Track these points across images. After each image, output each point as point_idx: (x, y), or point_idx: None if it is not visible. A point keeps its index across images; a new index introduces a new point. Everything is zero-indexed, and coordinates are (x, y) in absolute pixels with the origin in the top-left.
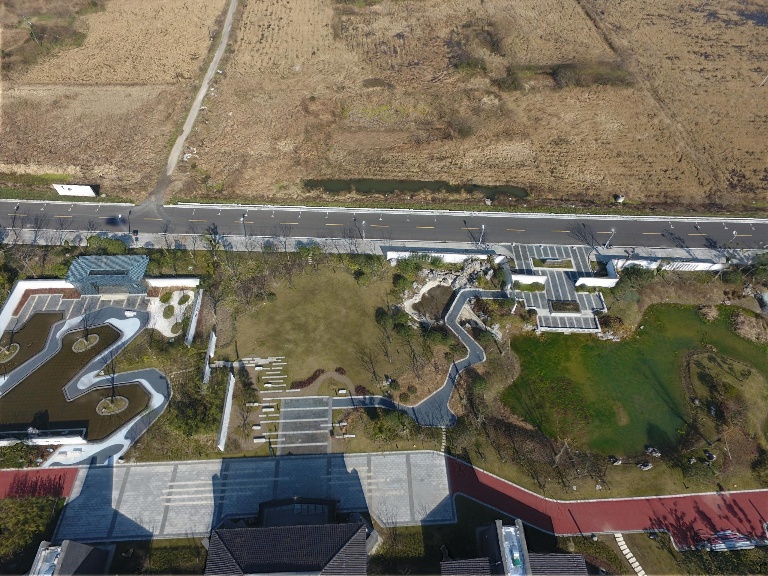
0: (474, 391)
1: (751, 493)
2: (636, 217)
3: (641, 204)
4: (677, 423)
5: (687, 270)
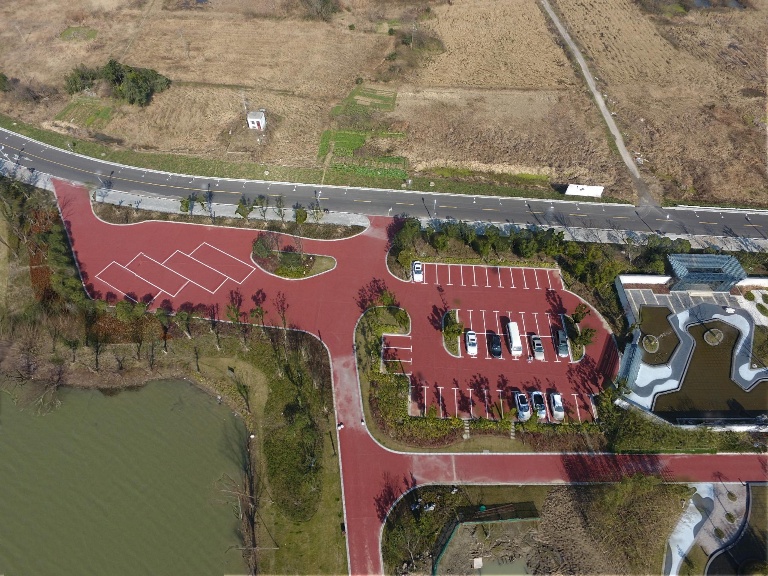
0: None
1: None
2: None
3: None
4: None
5: None
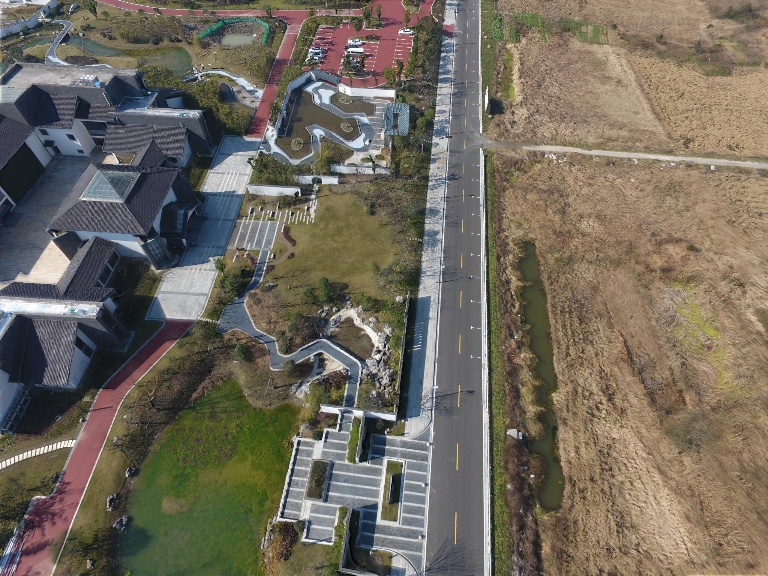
0: None
1: None
2: None
3: None
4: None
5: None
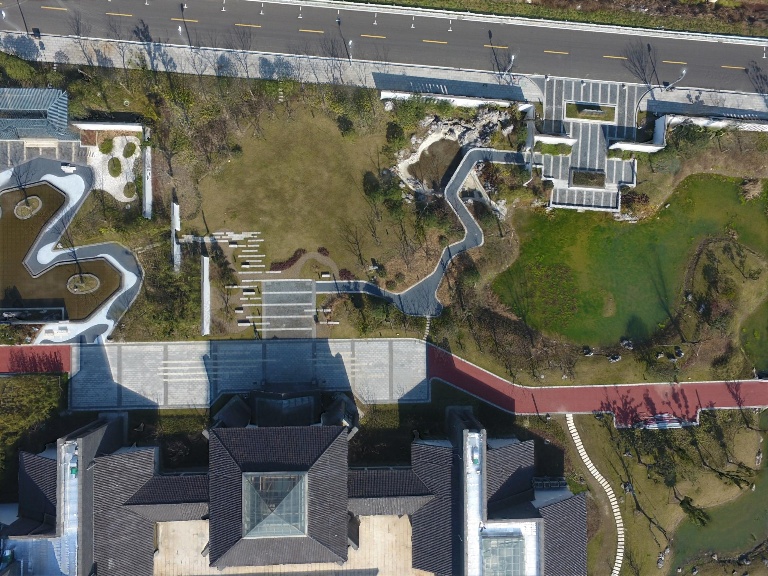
0: (465, 280)
1: (701, 384)
2: (724, 37)
3: (740, 8)
4: (661, 316)
5: (753, 130)
